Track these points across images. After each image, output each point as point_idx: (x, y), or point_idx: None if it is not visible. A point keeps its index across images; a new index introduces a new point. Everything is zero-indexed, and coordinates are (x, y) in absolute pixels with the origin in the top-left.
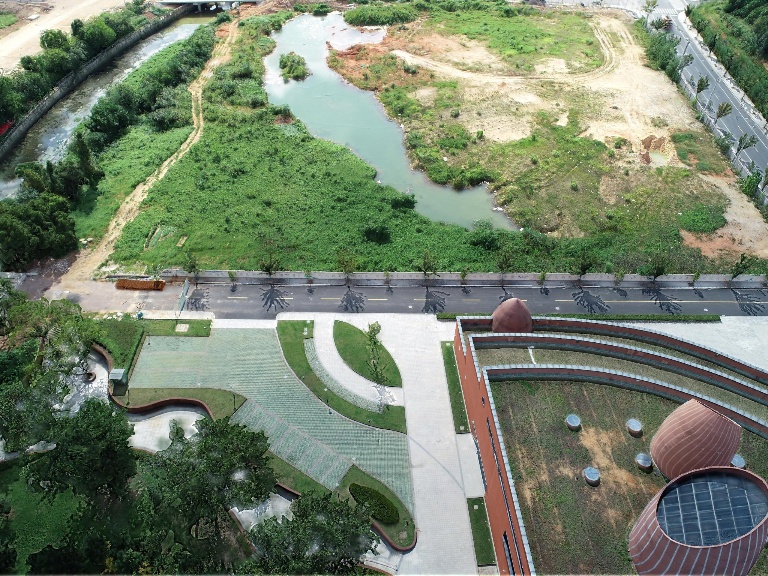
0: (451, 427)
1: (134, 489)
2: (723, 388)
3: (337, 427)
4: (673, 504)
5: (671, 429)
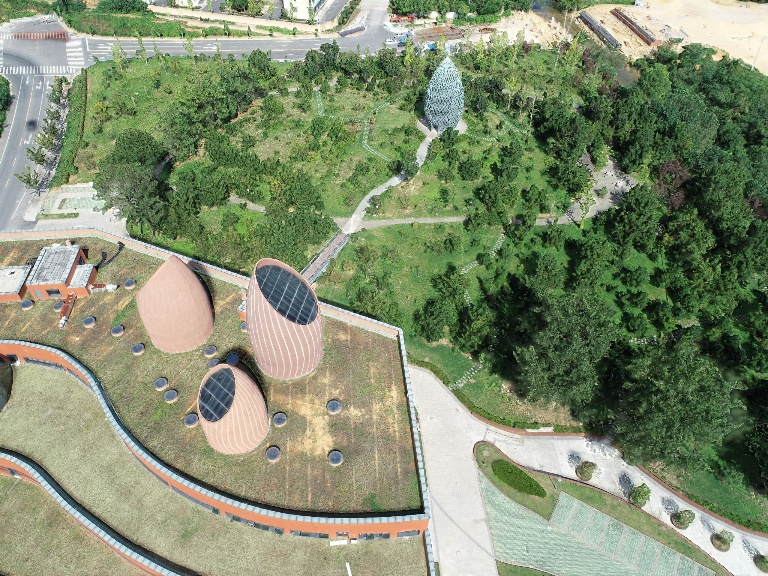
0: (444, 572)
1: (761, 496)
2: (126, 540)
3: (580, 569)
4: (303, 316)
5: (259, 401)
